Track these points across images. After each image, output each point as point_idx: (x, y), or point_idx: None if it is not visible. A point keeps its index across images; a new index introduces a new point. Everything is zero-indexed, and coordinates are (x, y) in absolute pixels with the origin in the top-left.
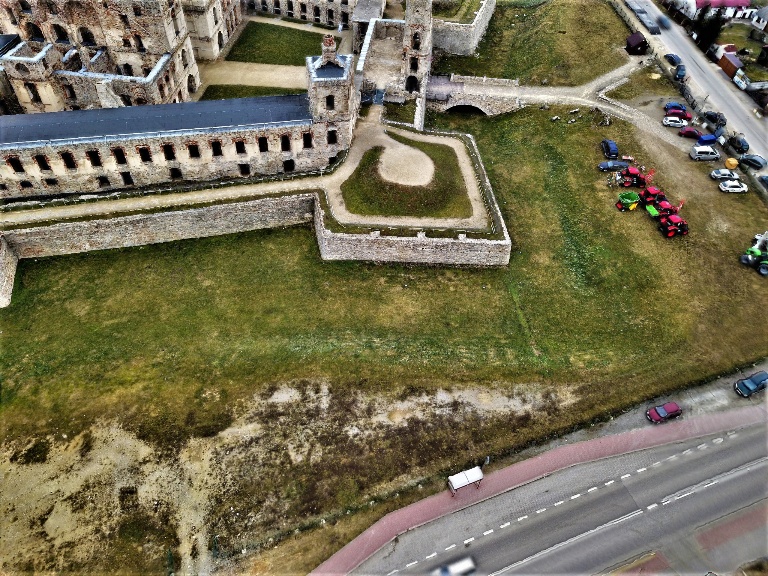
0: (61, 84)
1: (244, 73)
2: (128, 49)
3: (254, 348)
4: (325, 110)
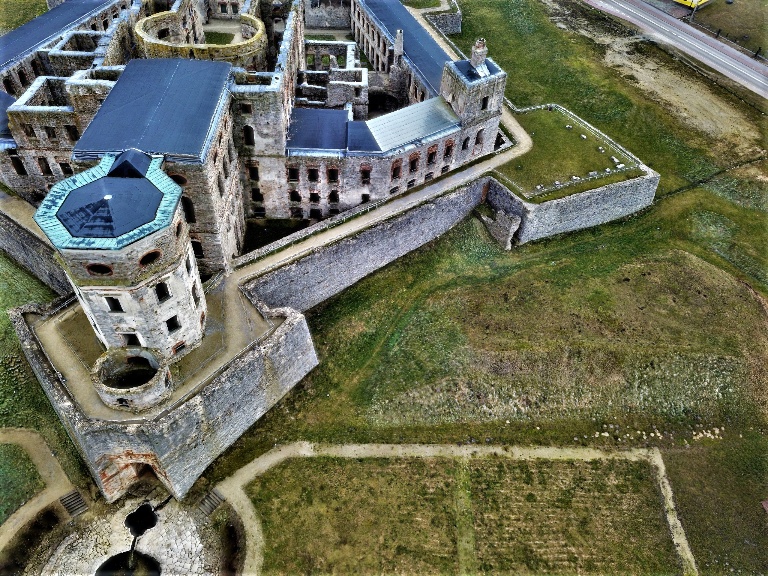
0: None
1: None
2: None
3: None
4: None
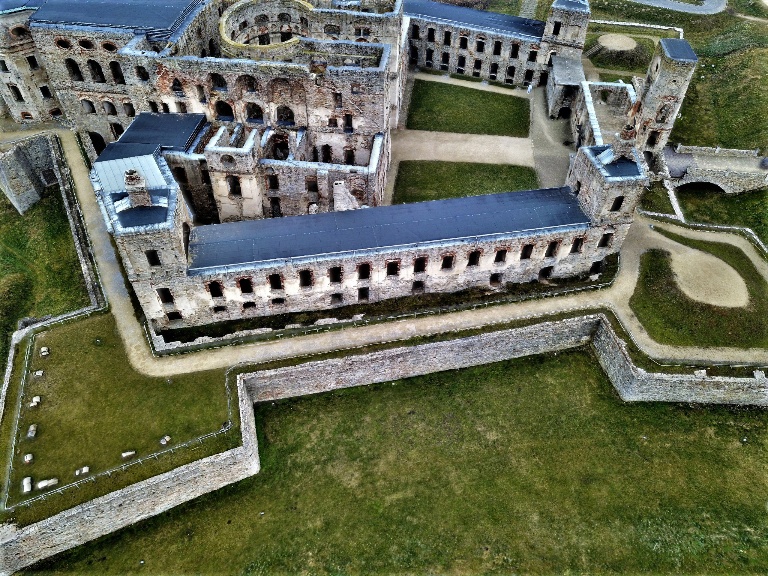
0: (264, 174)
1: (435, 145)
2: (333, 129)
3: (601, 544)
4: (608, 212)
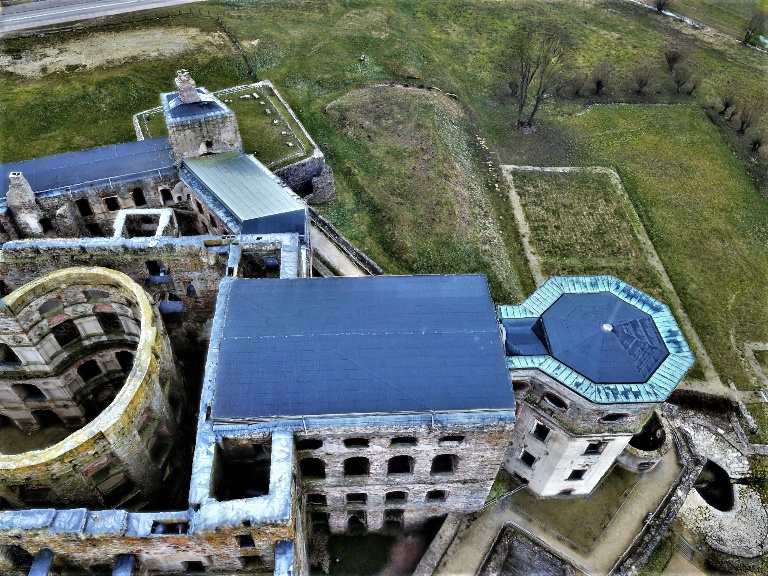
0: None
1: None
2: None
3: None
4: None
